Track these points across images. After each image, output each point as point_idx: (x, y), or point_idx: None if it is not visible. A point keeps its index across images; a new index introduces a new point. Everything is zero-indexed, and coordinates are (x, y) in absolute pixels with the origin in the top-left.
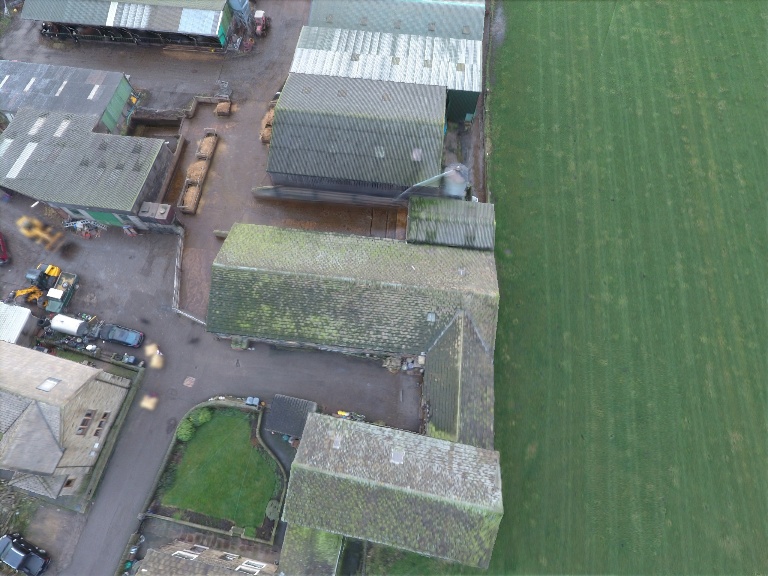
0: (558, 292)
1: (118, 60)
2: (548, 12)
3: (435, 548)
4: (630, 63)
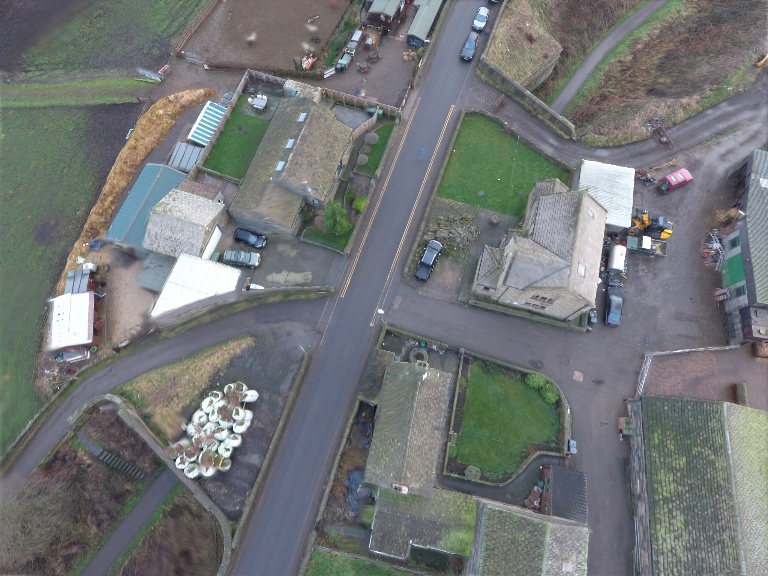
0: None
1: None
2: None
3: None
4: None
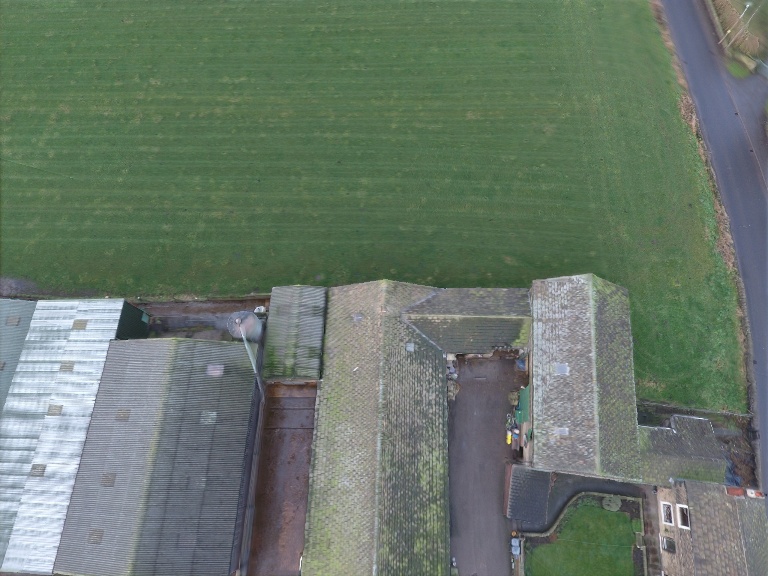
0: (360, 233)
1: None
2: None
3: (626, 332)
4: (89, 152)
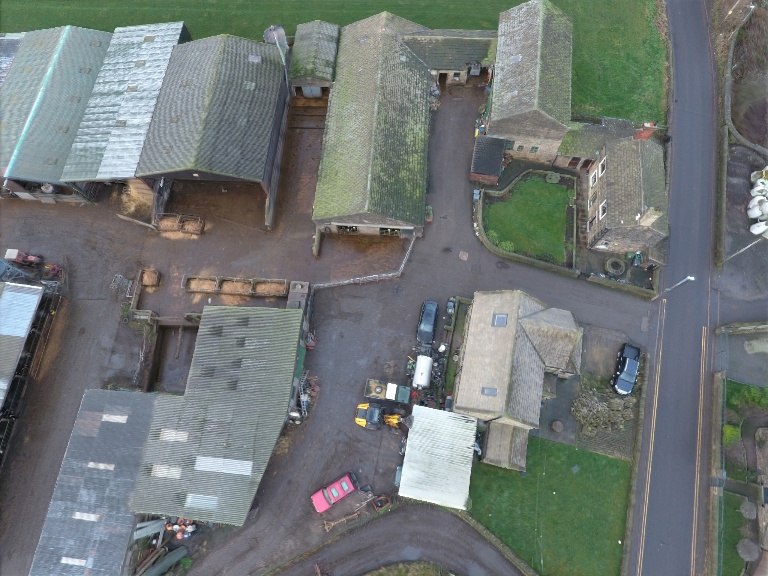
0: (367, 6)
1: (40, 441)
2: (73, 1)
3: (568, 42)
4: None
